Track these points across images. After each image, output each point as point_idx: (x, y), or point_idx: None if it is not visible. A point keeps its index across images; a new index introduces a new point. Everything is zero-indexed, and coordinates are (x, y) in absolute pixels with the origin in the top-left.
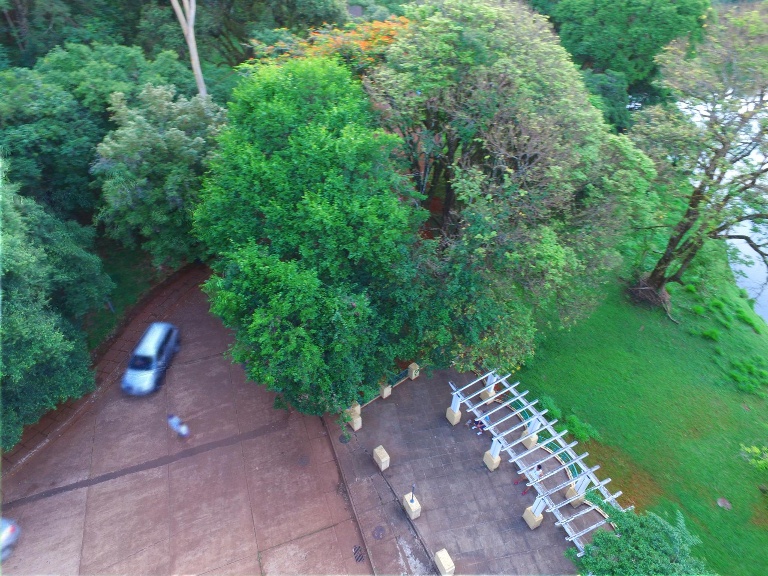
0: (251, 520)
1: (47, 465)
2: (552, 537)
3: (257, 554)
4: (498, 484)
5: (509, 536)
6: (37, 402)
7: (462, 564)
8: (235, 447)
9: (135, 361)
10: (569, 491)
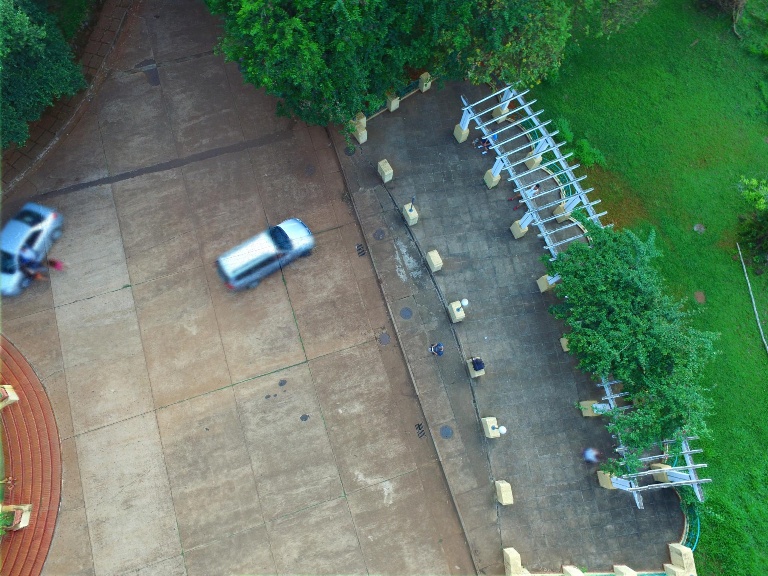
0: (265, 219)
1: (65, 162)
2: (532, 246)
3: (273, 246)
4: (493, 200)
5: (494, 243)
6: (30, 97)
7: (449, 262)
8: (242, 154)
9: (121, 56)
10: (558, 208)
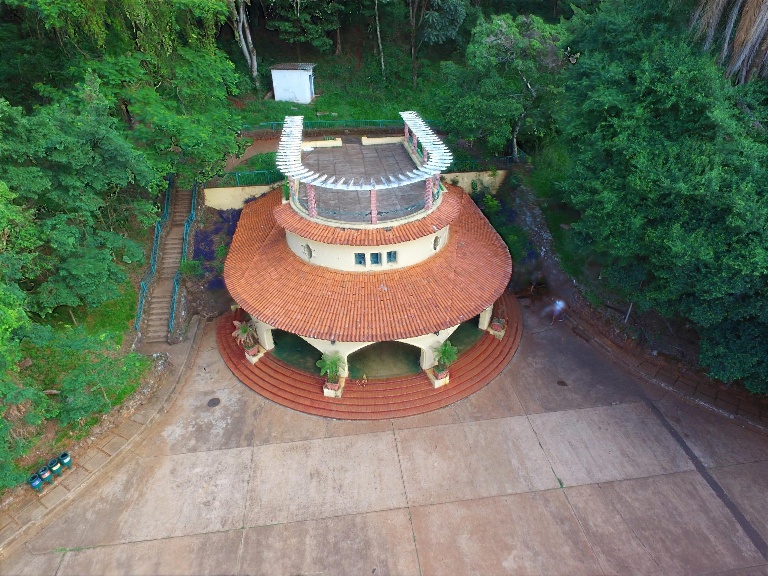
0: None
1: (704, 425)
2: None
3: None
4: None
5: None
6: None
7: None
8: None
9: None
10: None
